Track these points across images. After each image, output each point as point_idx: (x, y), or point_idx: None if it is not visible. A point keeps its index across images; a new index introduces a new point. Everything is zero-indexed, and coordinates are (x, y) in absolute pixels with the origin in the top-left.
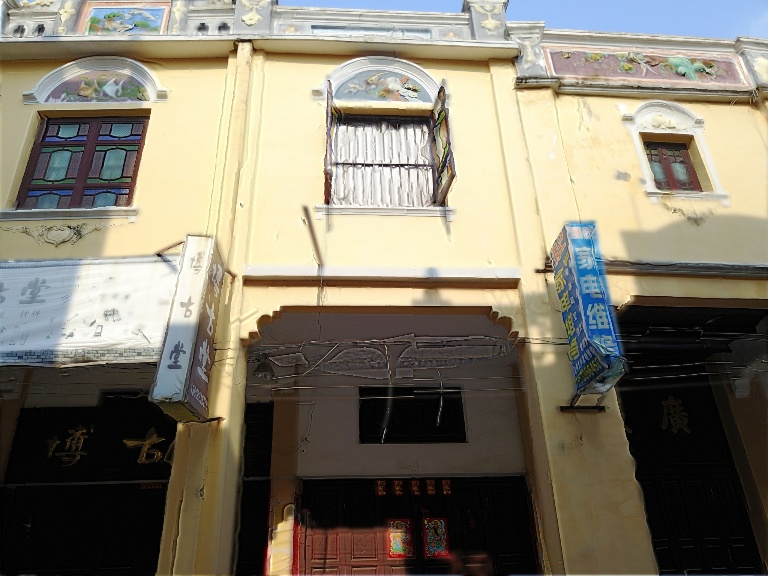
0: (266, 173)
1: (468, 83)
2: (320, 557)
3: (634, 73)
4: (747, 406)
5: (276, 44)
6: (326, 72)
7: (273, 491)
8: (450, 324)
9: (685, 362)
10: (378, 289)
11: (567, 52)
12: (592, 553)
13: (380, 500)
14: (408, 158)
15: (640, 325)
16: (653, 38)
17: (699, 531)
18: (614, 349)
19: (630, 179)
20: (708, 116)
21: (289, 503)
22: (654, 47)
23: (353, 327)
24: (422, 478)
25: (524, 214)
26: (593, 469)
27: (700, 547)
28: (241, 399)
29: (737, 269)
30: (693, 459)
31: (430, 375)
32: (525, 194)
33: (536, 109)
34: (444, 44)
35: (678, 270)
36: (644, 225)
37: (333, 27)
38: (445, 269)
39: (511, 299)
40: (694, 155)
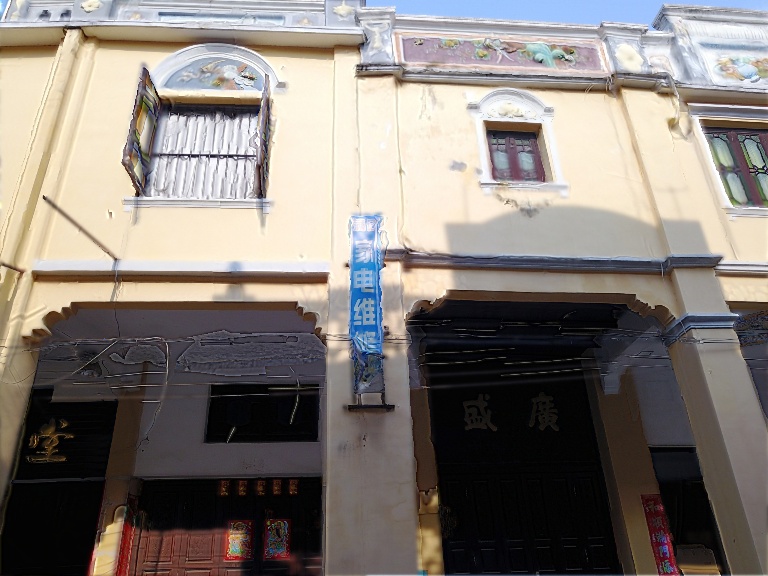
0: (78, 164)
1: (310, 71)
2: (153, 560)
3: (488, 60)
4: (616, 403)
5: (108, 31)
6: (158, 60)
7: (106, 492)
8: (262, 320)
9: (558, 358)
10: (177, 284)
11: (420, 38)
12: (356, 559)
13: (222, 501)
14: (238, 148)
15: (492, 320)
16: (512, 24)
17: (557, 531)
18: (376, 346)
19: (465, 169)
20: (560, 104)
21: (121, 504)
22: (514, 33)
23: (156, 324)
24: (268, 478)
25: (344, 206)
26: (371, 471)
27: (556, 547)
28: (21, 399)
29: (562, 262)
30: (558, 457)
31: (284, 372)
32: (348, 185)
33: (375, 97)
34: (284, 30)
35: (498, 263)
36: (472, 217)
37: (182, 14)
38: (250, 263)
39: (320, 294)
40: (541, 144)
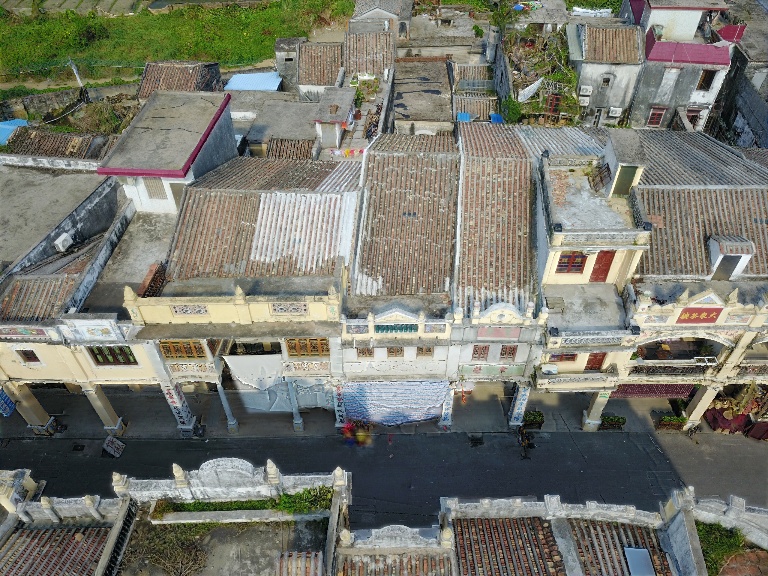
0: None
1: None
2: None
3: (8, 333)
4: None
5: None
6: None
7: None
8: None
9: None
10: None
11: None
12: None
13: None
14: None
15: None
16: None
17: None
18: None
19: None
20: None
21: None
22: None
23: None
24: None
25: None
26: None
27: None
28: None
29: None
30: None
31: None
32: None
33: None
34: None
35: None
36: (23, 371)
37: None
38: None
39: None
40: None
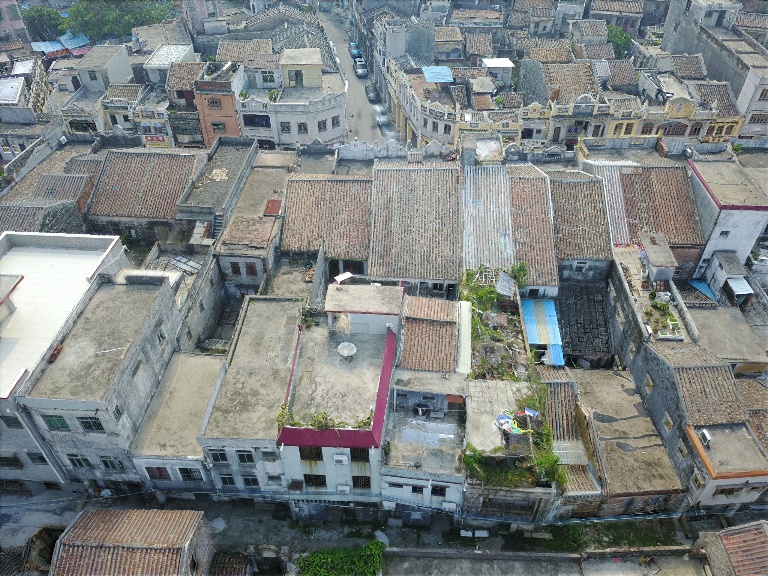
0: None
1: None
2: None
3: None
4: None
5: None
6: None
7: None
8: None
9: None
10: None
11: None
12: None
13: None
14: None
15: None
16: None
17: None
18: None
19: None
20: None
21: None
22: None
23: None
24: None
25: None
26: None
27: None
28: None
29: None
30: None
31: None
32: None
33: None
34: None
35: None
36: None
37: None
38: None
39: None
40: None
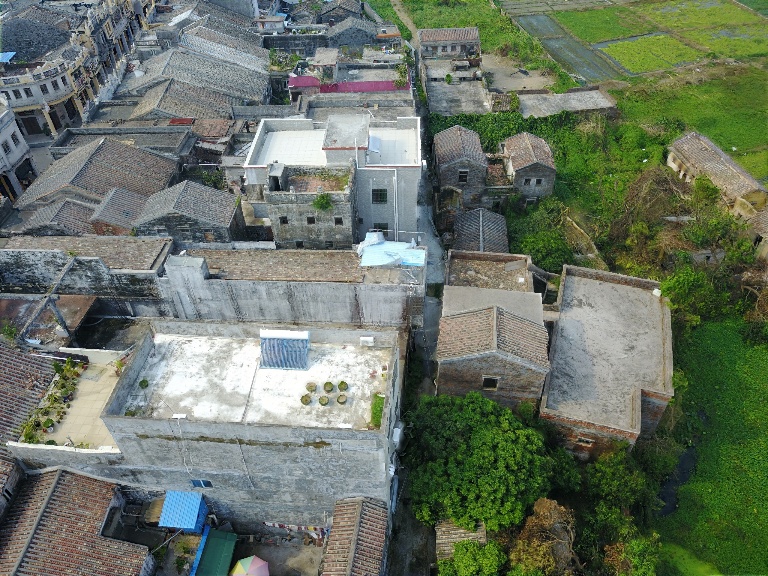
0: None
1: None
2: None
3: None
4: None
5: None
6: None
7: None
8: None
9: None
10: None
11: None
12: None
13: None
14: None
15: None
16: None
17: None
18: None
19: None
20: None
21: None
22: (162, 2)
23: None
24: None
25: None
26: None
27: None
28: None
29: None
30: None
31: None
32: None
33: None
34: None
35: None
36: None
37: None
38: None
39: None
40: None
